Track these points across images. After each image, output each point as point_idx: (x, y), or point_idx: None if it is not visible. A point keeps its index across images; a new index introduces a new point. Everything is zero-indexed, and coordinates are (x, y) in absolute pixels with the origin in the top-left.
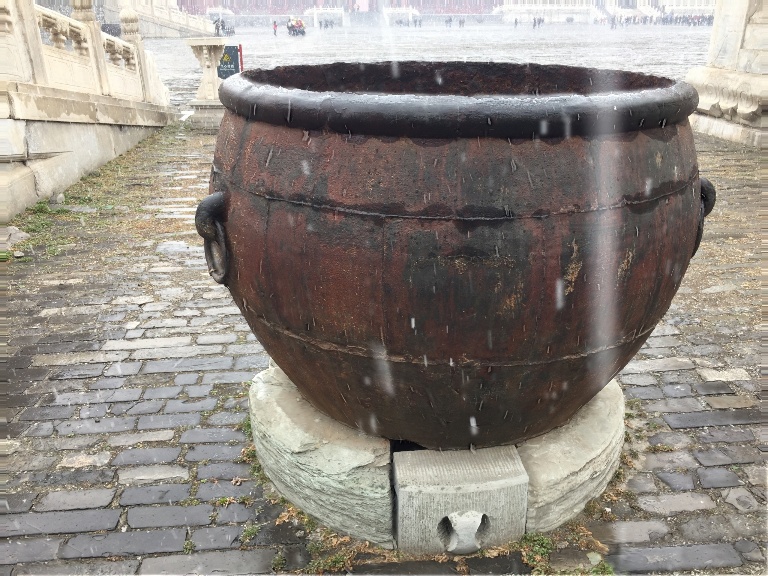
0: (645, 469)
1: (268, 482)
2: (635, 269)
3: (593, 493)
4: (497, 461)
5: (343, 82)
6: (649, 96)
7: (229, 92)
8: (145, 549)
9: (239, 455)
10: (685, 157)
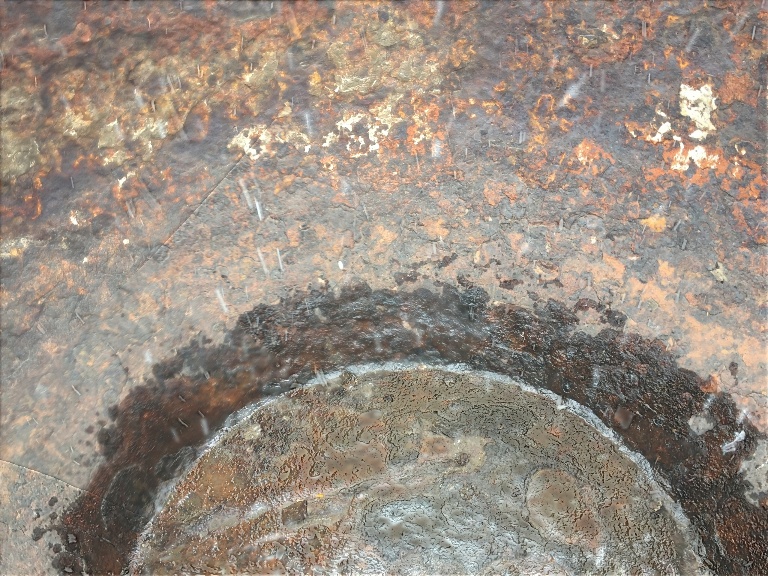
0: None
1: None
2: None
3: None
4: None
5: None
6: None
7: None
8: None
9: None
10: None
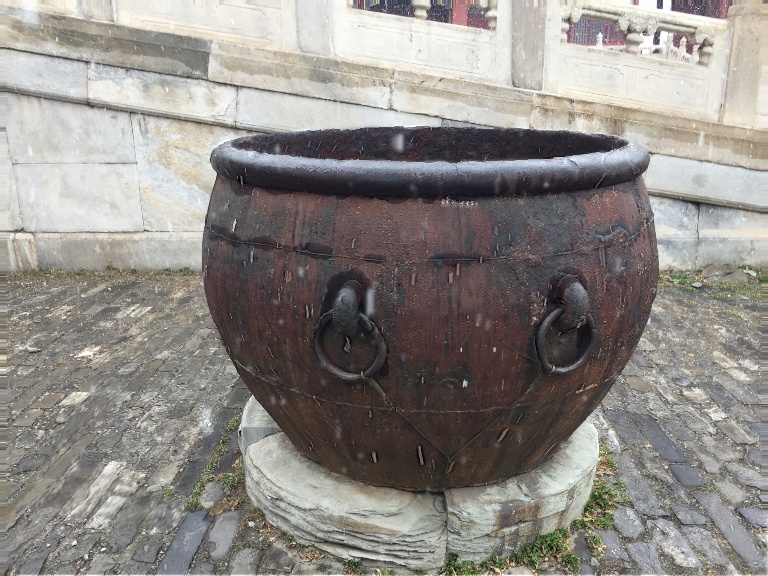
0: (298, 569)
1: None
2: (208, 282)
3: (265, 509)
4: (268, 417)
5: (572, 150)
6: (235, 153)
7: None
8: None
9: None
10: (252, 219)
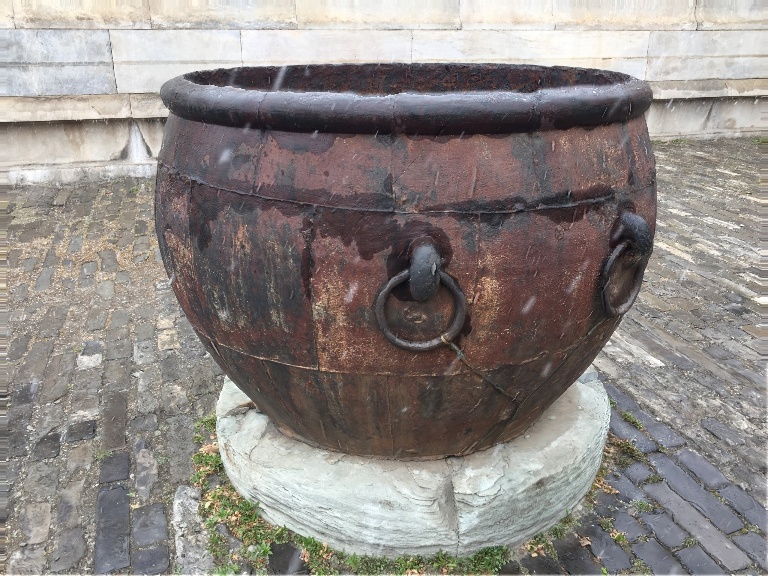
0: None
1: (572, 514)
2: None
3: None
4: None
5: None
6: None
7: (606, 102)
8: (722, 574)
9: (543, 557)
10: None
